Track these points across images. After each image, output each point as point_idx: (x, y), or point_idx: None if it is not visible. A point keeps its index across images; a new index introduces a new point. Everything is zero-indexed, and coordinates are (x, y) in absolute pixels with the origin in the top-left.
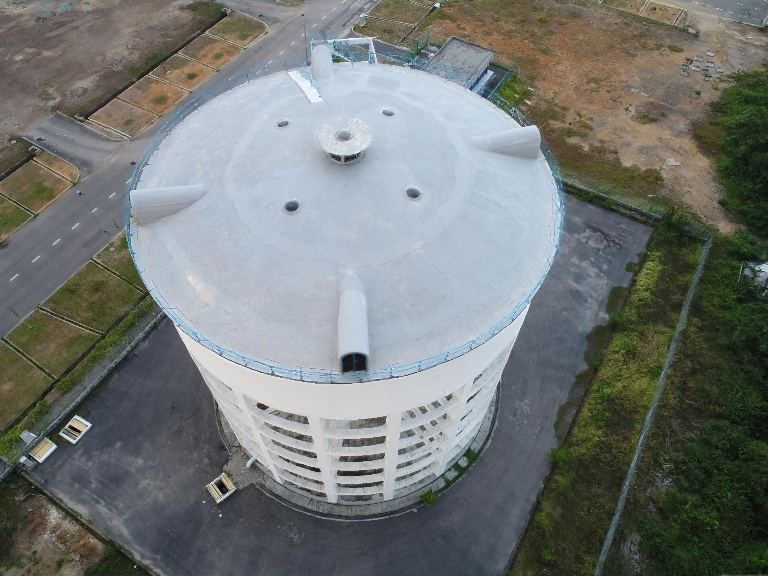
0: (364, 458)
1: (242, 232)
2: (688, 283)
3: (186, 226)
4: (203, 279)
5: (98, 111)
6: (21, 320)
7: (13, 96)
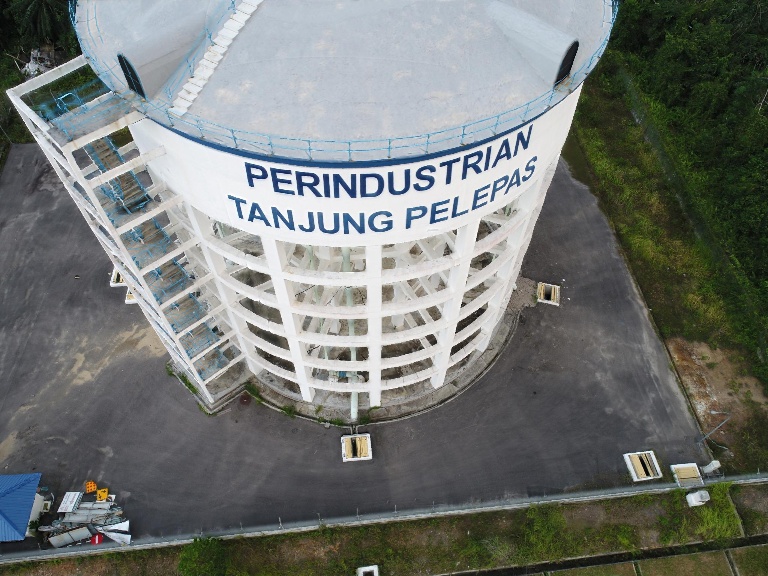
0: None
1: None
2: None
3: (539, 8)
4: None
5: None
6: None
7: None
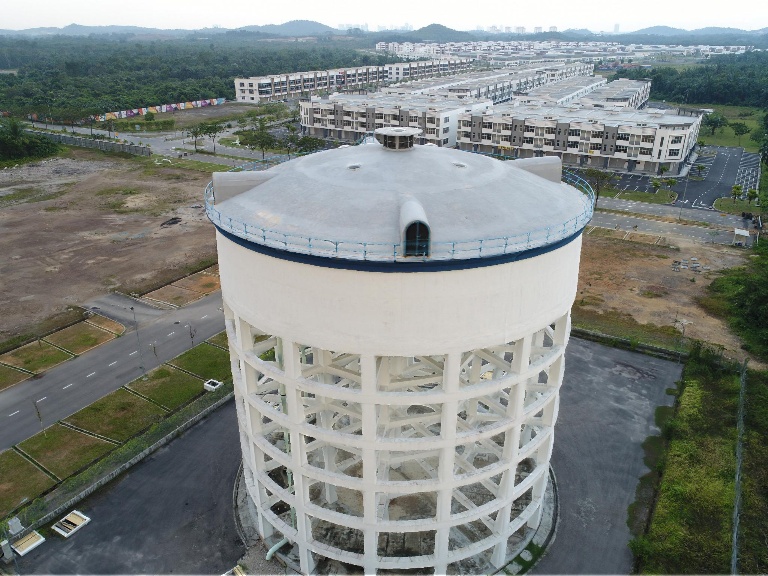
0: (407, 549)
1: (310, 182)
2: (735, 405)
3: (259, 191)
4: (272, 212)
5: (152, 292)
6: (38, 432)
7: (79, 283)
